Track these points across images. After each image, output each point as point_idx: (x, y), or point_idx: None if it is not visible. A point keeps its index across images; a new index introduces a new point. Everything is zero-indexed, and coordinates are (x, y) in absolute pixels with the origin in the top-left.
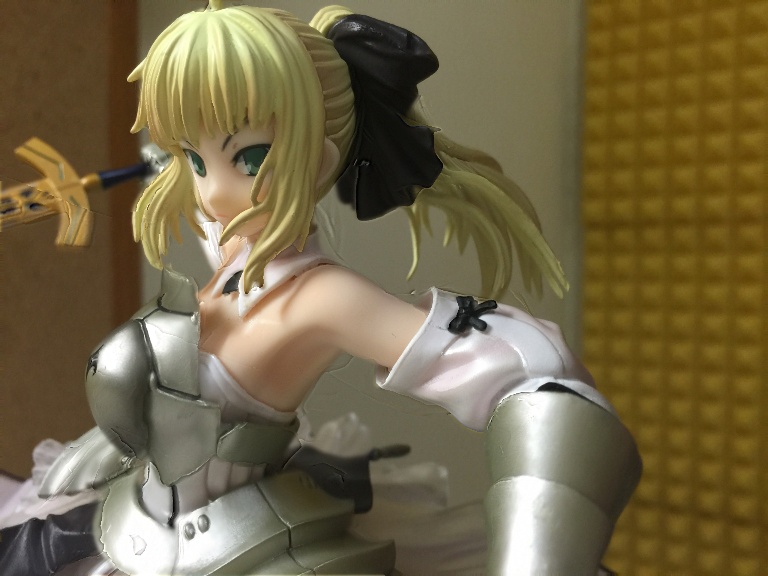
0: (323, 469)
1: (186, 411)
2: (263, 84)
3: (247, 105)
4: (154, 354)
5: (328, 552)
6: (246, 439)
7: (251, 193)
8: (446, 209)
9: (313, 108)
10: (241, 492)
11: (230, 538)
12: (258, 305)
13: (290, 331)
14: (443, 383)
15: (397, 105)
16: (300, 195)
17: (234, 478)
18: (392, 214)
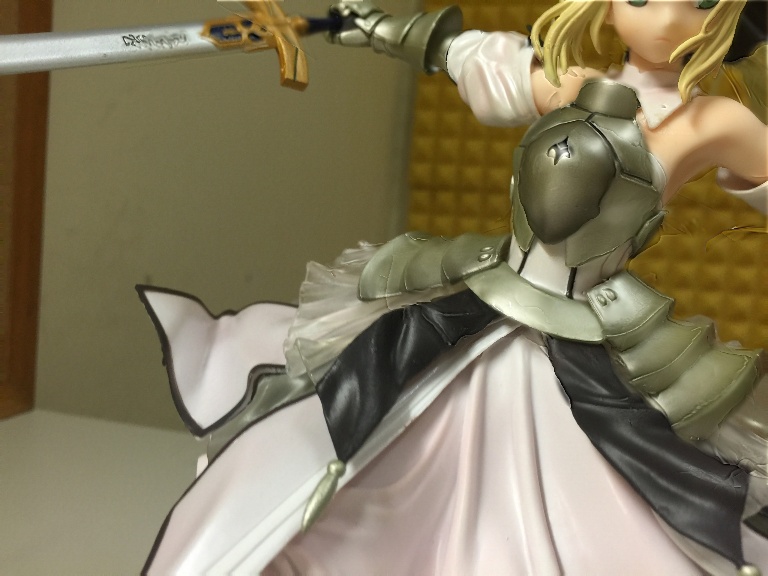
0: (642, 269)
1: (641, 194)
2: None
3: None
4: (612, 147)
5: None
6: None
7: (707, 22)
8: (746, 69)
9: None
10: (623, 274)
11: (636, 304)
12: (666, 120)
13: (703, 140)
14: None
15: None
16: None
17: (620, 263)
18: None
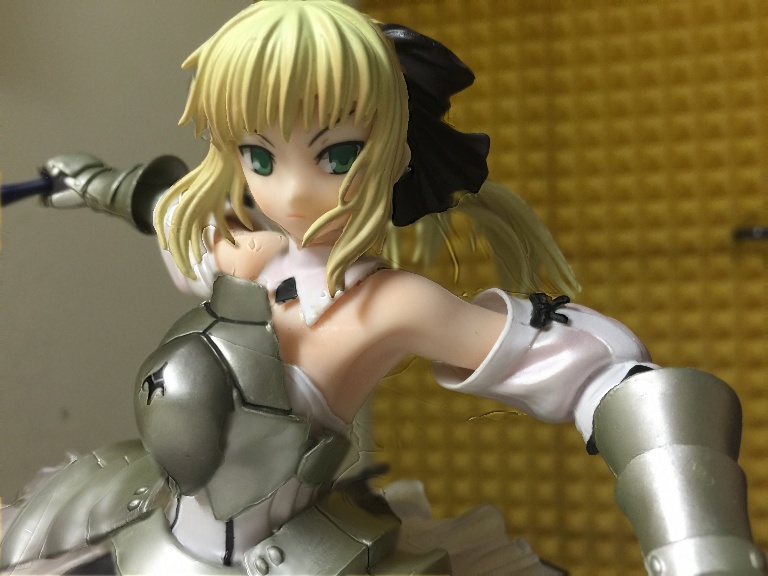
0: (362, 485)
1: (277, 428)
2: (376, 78)
3: (356, 99)
4: (231, 369)
5: (402, 566)
6: (325, 455)
7: (341, 191)
8: (469, 216)
9: (403, 107)
10: (305, 516)
11: (311, 566)
12: (327, 311)
13: (373, 336)
14: (530, 376)
15: (437, 113)
16: (387, 195)
17: (297, 502)
18: (422, 221)
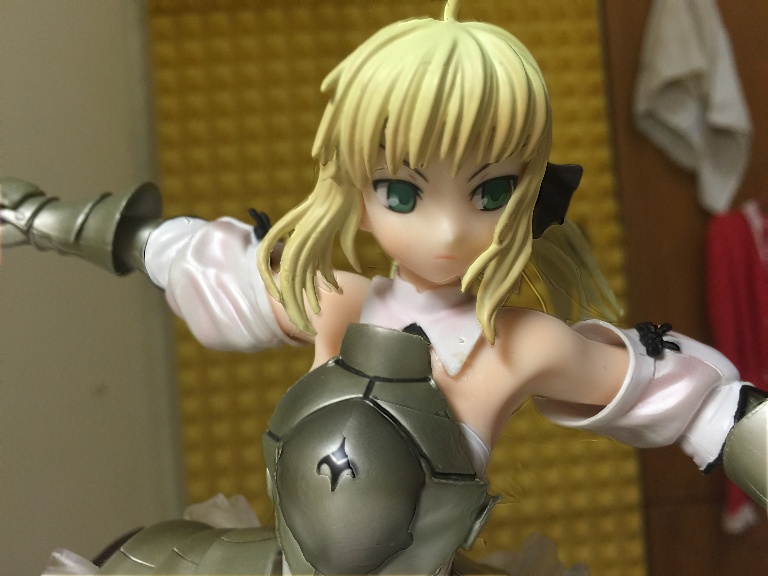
0: None
1: (465, 496)
2: (549, 110)
3: (531, 132)
4: (412, 436)
5: None
6: None
7: (500, 230)
8: None
9: None
10: None
11: None
12: (468, 359)
13: (521, 381)
14: (654, 406)
15: None
16: None
17: None
18: None
